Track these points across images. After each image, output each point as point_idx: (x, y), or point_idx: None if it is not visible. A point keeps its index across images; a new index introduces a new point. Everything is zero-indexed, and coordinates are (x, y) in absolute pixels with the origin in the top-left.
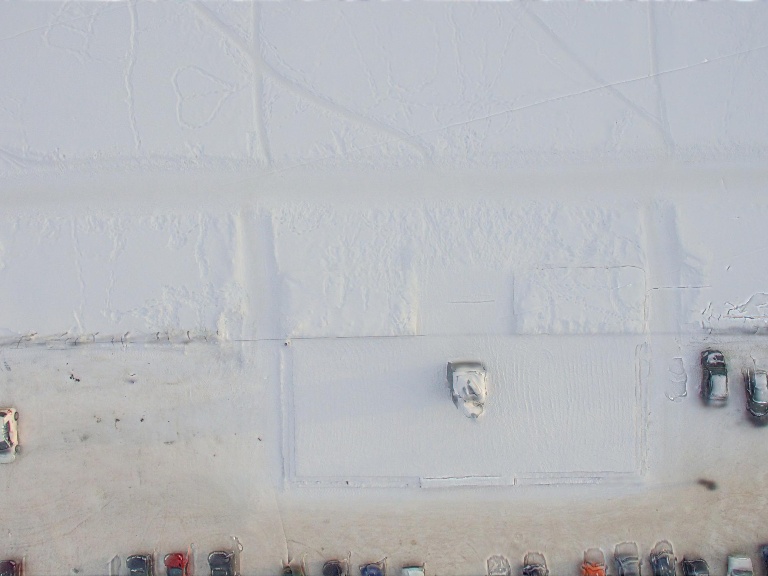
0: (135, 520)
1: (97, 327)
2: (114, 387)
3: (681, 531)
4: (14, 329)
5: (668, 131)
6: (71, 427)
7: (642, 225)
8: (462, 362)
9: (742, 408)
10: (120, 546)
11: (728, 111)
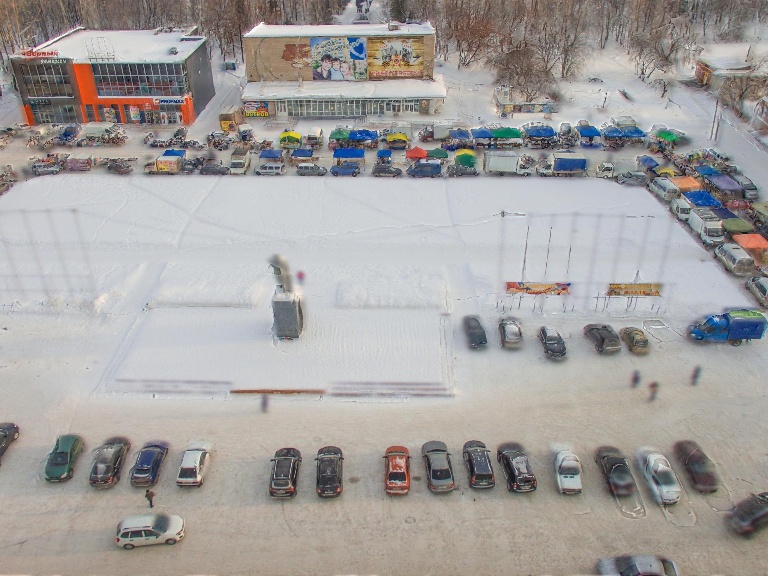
0: None
1: None
2: None
3: (496, 439)
4: None
5: (461, 239)
6: None
7: (445, 272)
8: None
9: (542, 355)
10: None
11: None
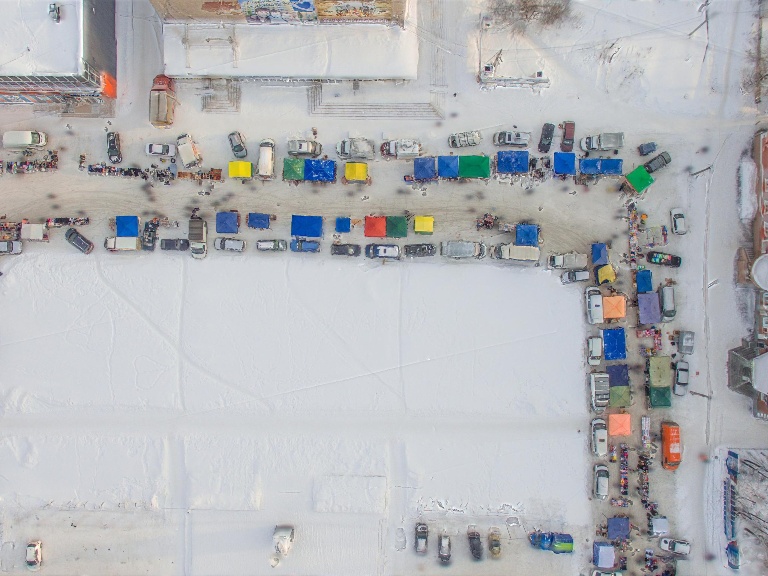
0: None
1: (87, 499)
2: (95, 531)
3: None
4: (42, 498)
5: (404, 400)
6: (71, 553)
7: (388, 452)
8: (283, 526)
9: (437, 556)
10: None
11: (439, 389)
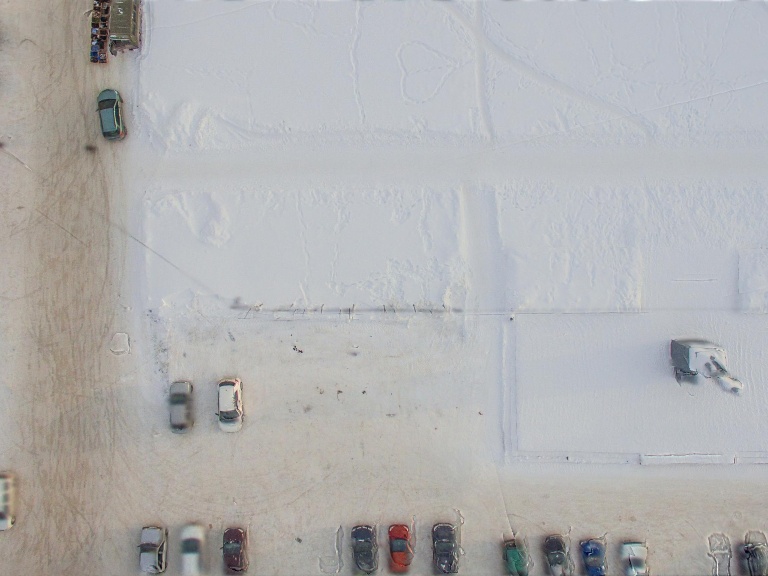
0: (358, 491)
1: (323, 299)
2: (337, 359)
3: None
4: (240, 300)
5: None
6: (296, 398)
7: None
8: (687, 340)
9: None
10: (344, 516)
11: None
